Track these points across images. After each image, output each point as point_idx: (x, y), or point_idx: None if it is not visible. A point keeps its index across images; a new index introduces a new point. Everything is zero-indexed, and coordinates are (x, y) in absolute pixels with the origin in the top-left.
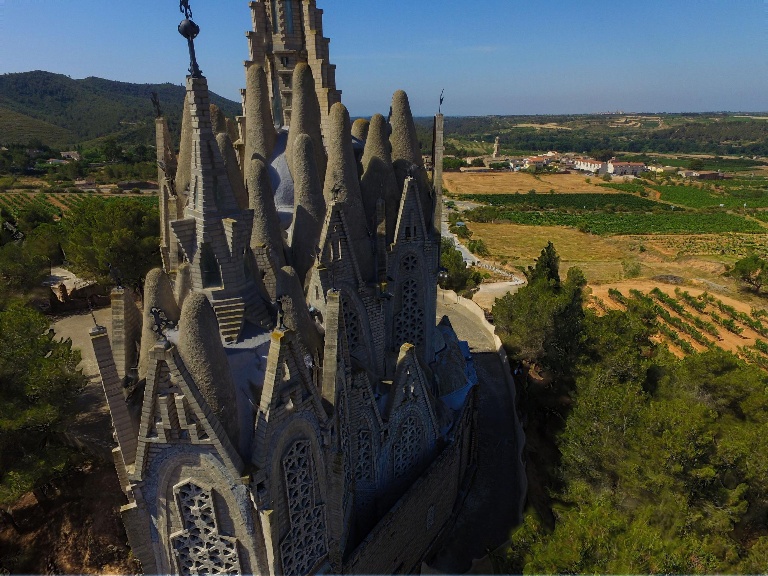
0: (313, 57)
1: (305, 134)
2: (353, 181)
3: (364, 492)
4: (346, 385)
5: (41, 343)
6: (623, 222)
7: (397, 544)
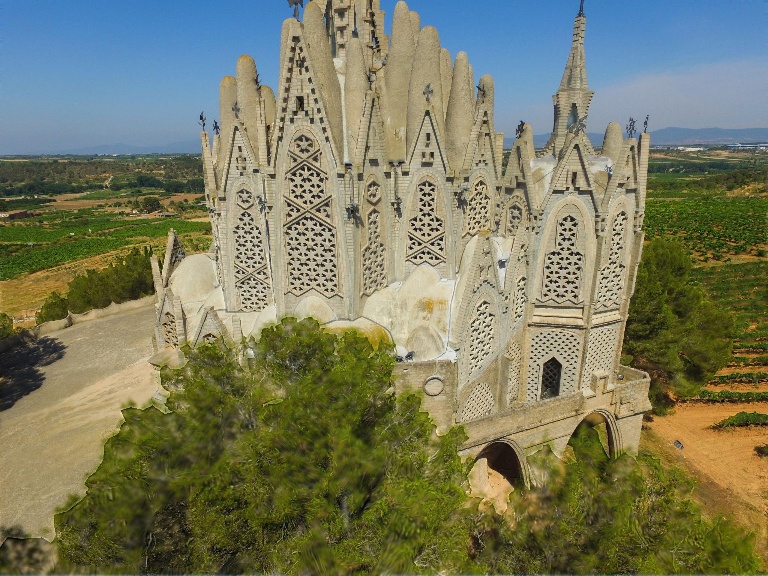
0: (377, 7)
1: None
2: None
3: None
4: None
5: (336, 339)
6: (5, 266)
7: None
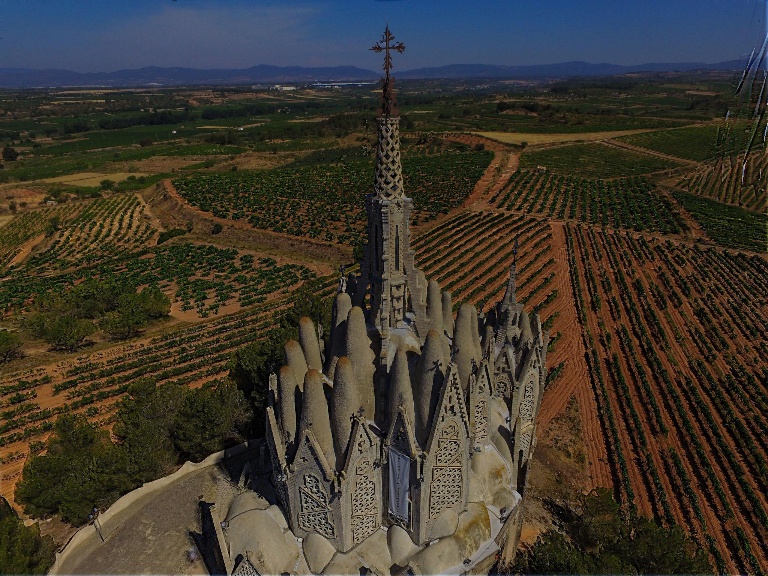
0: None
1: None
2: None
3: None
4: None
5: None
6: None
7: None
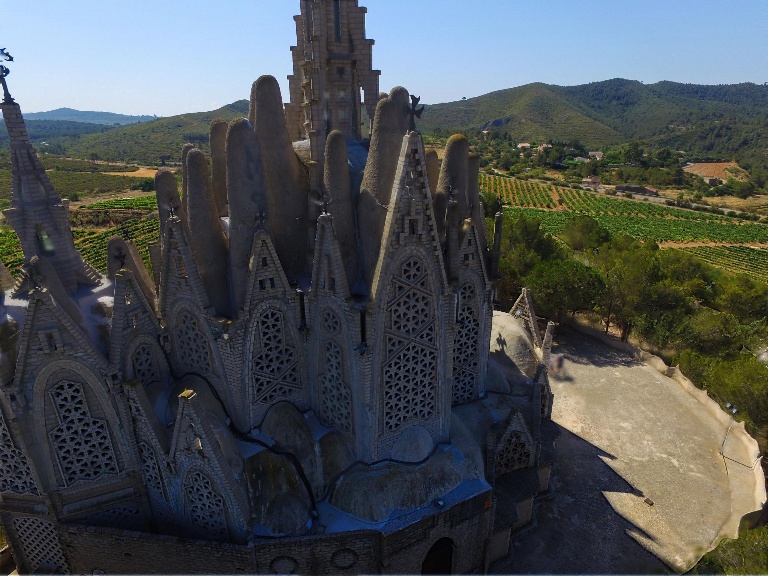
0: None
1: (194, 149)
2: (237, 203)
3: (161, 504)
4: (107, 385)
5: None
6: None
7: (140, 571)
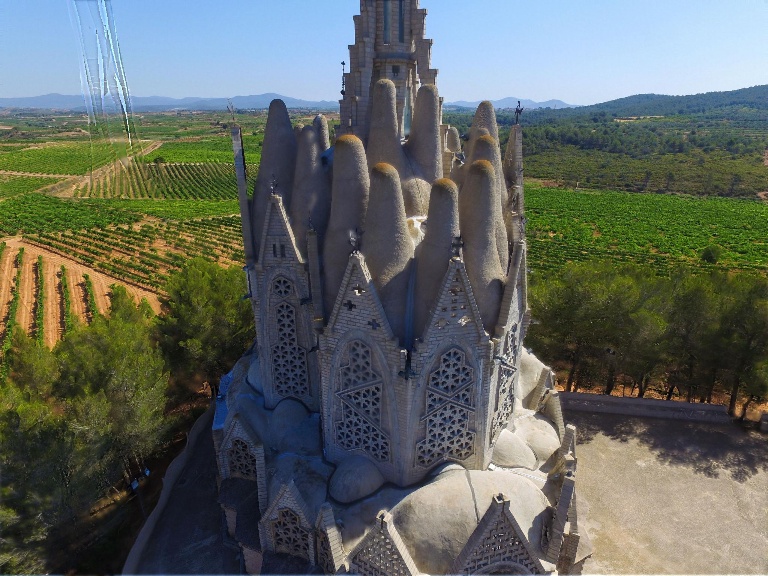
0: None
1: None
2: None
3: None
4: None
5: None
6: None
7: None
